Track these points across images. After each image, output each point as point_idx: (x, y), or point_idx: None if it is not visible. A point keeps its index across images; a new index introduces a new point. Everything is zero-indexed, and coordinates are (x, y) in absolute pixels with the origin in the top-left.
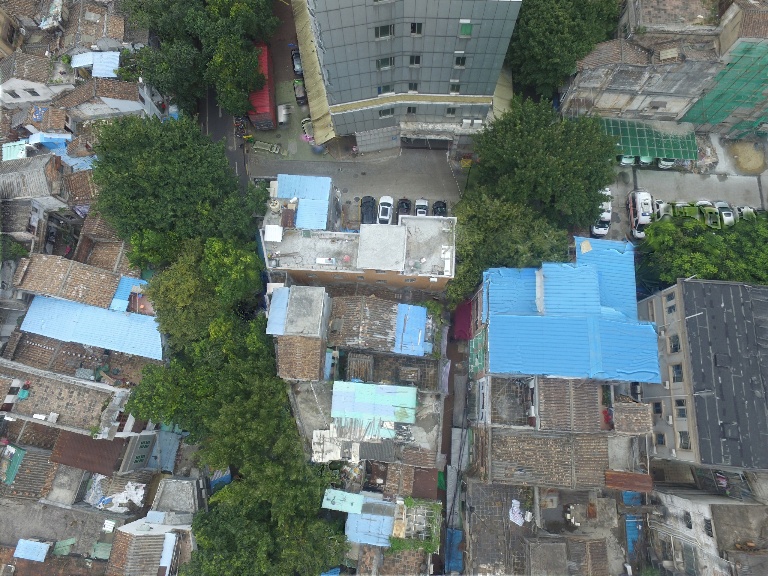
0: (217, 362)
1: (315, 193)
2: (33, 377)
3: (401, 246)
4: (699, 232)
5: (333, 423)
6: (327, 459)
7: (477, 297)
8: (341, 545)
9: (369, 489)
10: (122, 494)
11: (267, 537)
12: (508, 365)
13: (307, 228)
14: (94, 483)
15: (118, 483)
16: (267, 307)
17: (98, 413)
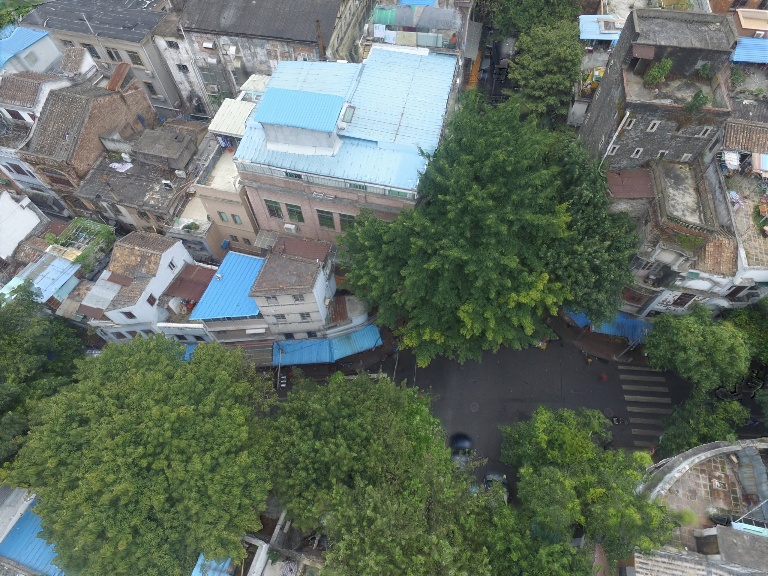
0: None
1: None
2: None
3: None
4: (5, 13)
5: None
6: None
7: None
8: None
9: None
10: None
11: None
12: None
13: None
14: None
15: None
16: None
17: None
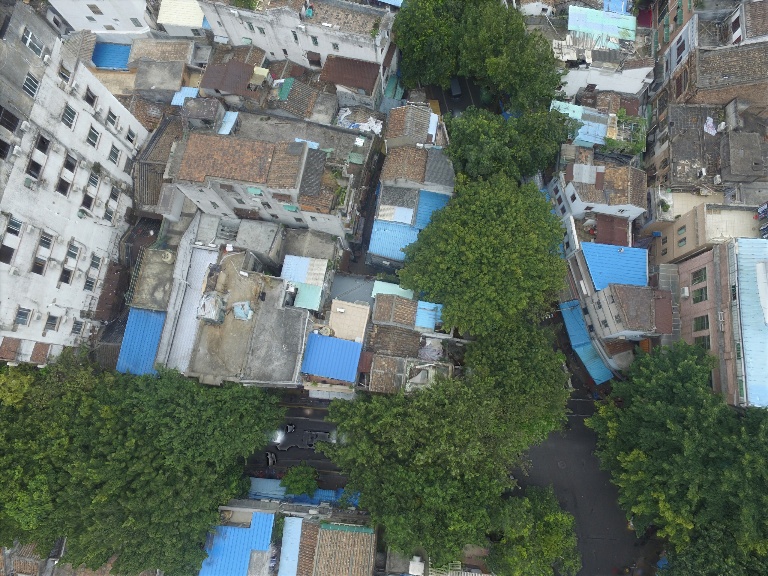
0: (457, 9)
1: None
2: (314, 3)
3: None
4: None
5: (569, 35)
6: (566, 57)
7: None
8: (575, 123)
9: (586, 106)
10: (366, 124)
11: (513, 117)
12: None
13: None
14: (340, 120)
15: (363, 116)
16: None
17: (370, 29)
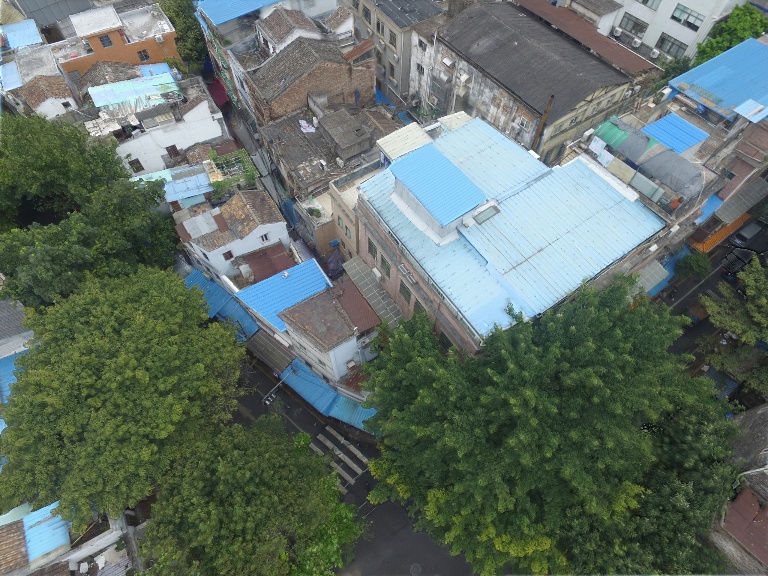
0: None
1: (21, 29)
2: None
3: (113, 15)
4: None
5: (101, 111)
6: (106, 130)
7: (213, 59)
8: (155, 183)
9: None
10: None
11: None
12: (227, 16)
13: (23, 45)
14: None
15: None
16: (2, 88)
17: None
